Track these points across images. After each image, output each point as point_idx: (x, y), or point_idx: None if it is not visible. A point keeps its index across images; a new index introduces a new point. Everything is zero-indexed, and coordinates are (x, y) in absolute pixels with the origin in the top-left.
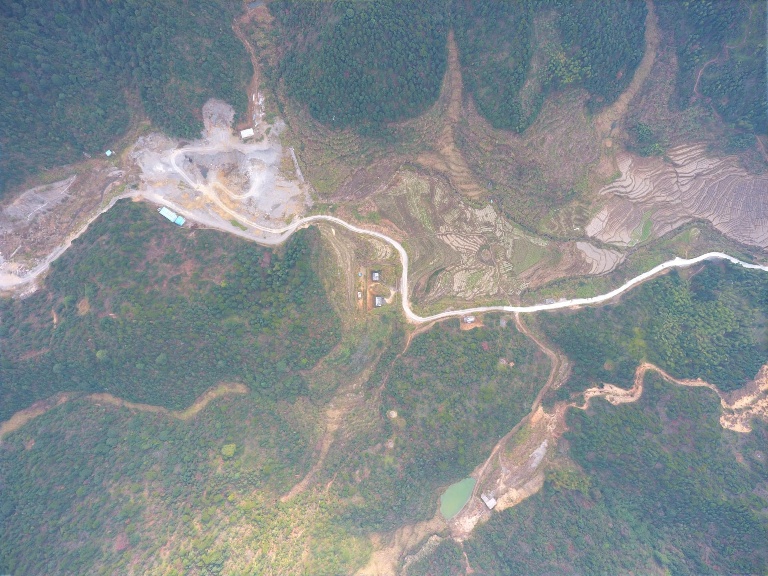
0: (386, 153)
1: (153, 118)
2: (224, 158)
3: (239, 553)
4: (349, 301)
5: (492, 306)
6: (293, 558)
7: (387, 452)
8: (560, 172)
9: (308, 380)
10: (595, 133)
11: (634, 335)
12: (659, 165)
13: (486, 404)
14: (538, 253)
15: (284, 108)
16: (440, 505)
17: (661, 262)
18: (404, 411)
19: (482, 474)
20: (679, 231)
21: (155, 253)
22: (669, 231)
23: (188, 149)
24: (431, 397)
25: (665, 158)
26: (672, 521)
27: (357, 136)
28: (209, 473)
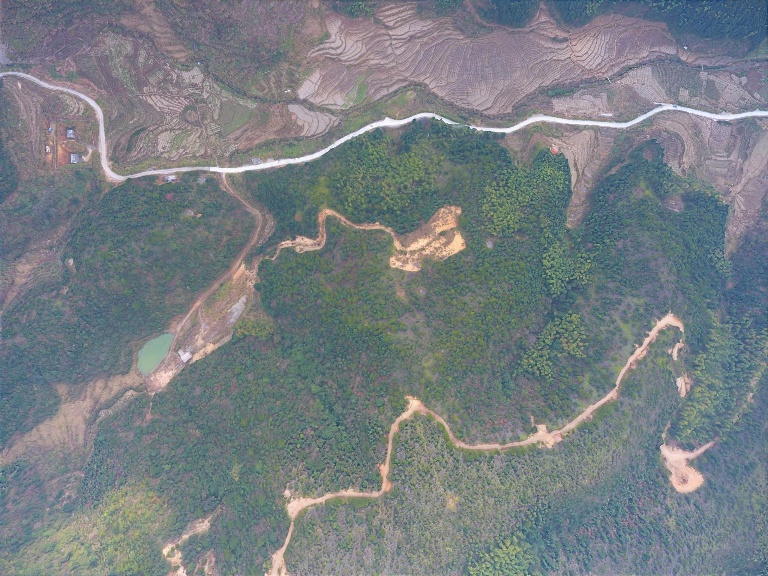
0: (86, 13)
1: None
2: None
3: None
4: (33, 153)
5: (197, 166)
6: None
7: (60, 297)
8: (260, 30)
9: None
10: None
11: (316, 182)
12: (370, 27)
13: (156, 247)
14: (245, 114)
15: None
16: (137, 361)
17: (369, 122)
18: (73, 255)
19: (180, 330)
20: (395, 94)
21: None
22: (385, 95)
23: None
24: (97, 239)
25: (375, 19)
26: (333, 356)
27: None
28: None
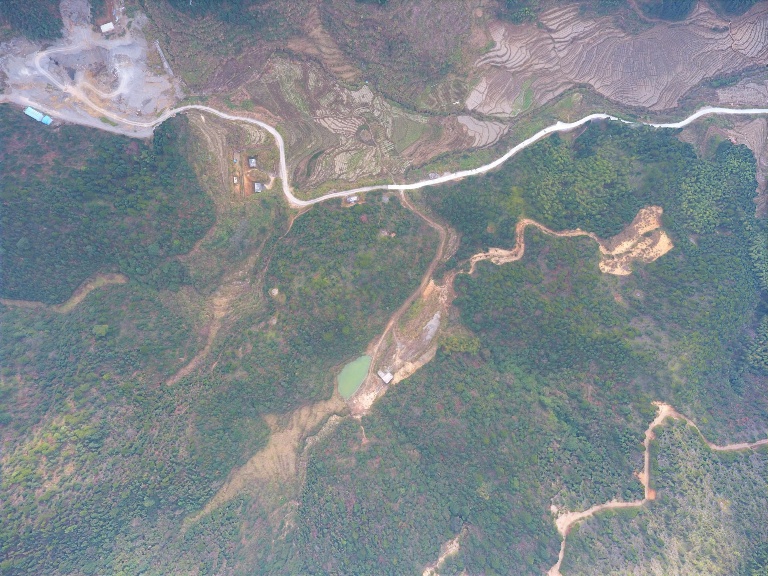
0: (254, 41)
1: (11, 20)
2: (89, 57)
3: (120, 432)
4: (224, 185)
5: (376, 185)
6: (176, 433)
7: (270, 328)
8: (430, 44)
9: (187, 266)
10: (464, 3)
11: (511, 193)
12: (533, 32)
13: (364, 271)
14: (418, 129)
15: (144, 1)
16: (337, 385)
17: (542, 127)
18: (282, 284)
19: (377, 351)
20: (561, 97)
21: (16, 146)
22: (551, 99)
23: (51, 50)
24: (307, 267)
25: (538, 24)
26: (556, 367)
27: (220, 23)
28: (81, 353)
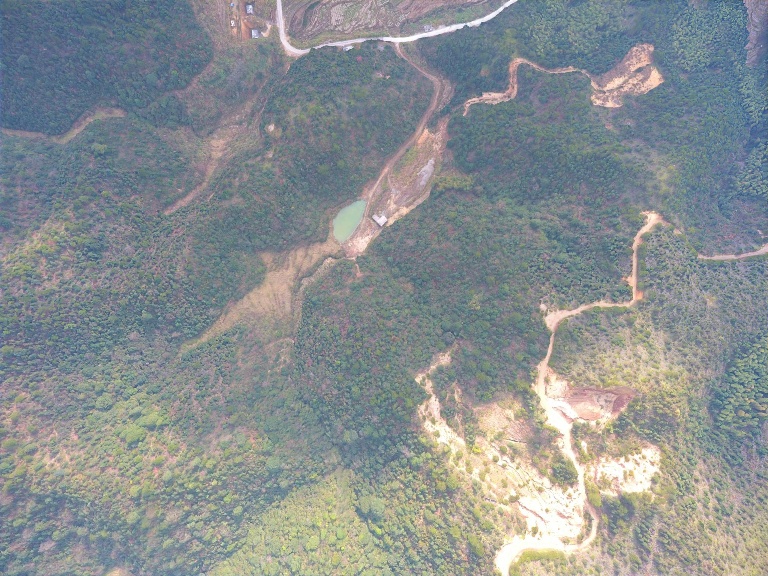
0: None
1: None
2: None
3: (119, 249)
4: (221, 26)
5: (371, 37)
6: (173, 251)
7: (266, 161)
8: None
9: (185, 103)
10: None
11: (504, 33)
12: None
13: (359, 103)
14: None
15: None
16: (333, 229)
17: None
18: (278, 116)
19: (372, 196)
20: None
21: None
22: None
23: None
24: (302, 97)
25: None
26: (548, 193)
27: None
28: (80, 168)
